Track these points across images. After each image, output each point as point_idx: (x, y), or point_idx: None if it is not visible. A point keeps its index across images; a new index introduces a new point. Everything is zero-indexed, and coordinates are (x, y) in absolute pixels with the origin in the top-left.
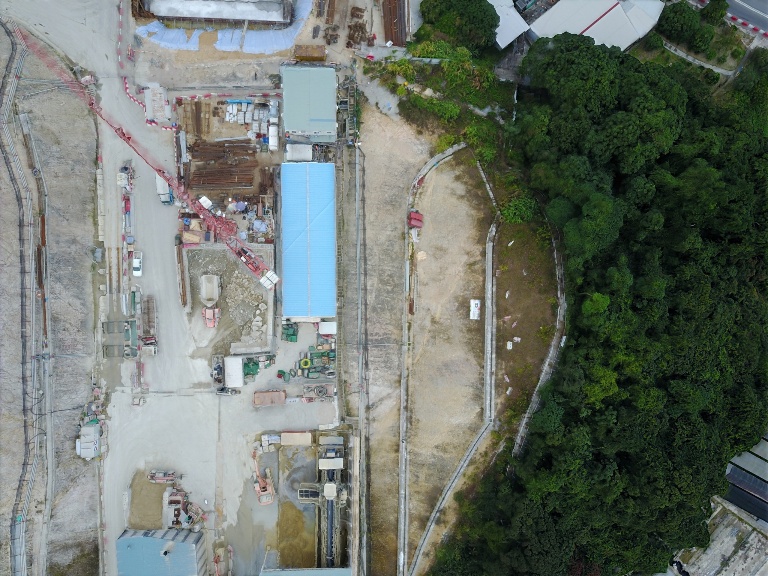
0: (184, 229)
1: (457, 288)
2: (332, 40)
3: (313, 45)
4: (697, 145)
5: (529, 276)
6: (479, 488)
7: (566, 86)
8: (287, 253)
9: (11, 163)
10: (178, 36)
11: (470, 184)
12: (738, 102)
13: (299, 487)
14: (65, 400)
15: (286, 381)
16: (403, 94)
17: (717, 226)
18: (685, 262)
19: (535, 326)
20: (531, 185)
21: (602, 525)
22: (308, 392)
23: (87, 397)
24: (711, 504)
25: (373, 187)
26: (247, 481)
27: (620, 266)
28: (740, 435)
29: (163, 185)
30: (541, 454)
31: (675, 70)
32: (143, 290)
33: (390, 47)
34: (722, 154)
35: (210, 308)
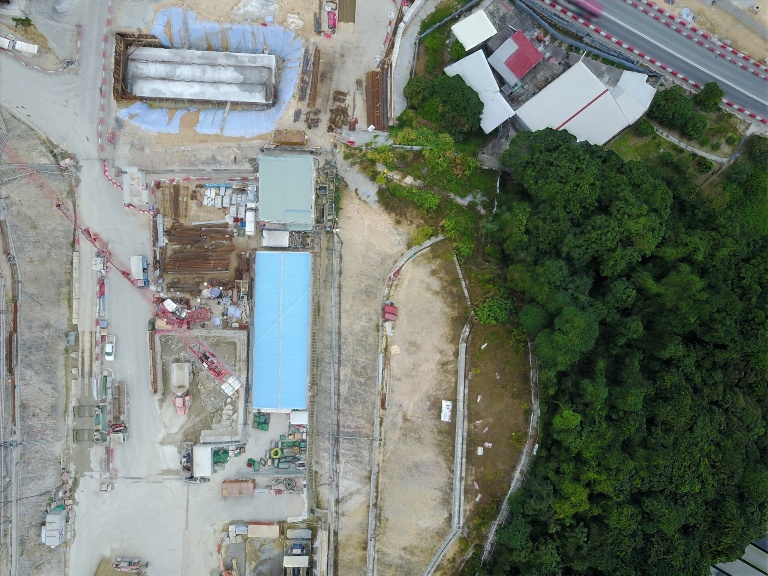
0: (157, 315)
1: (429, 387)
2: (313, 124)
3: (293, 130)
4: (680, 249)
5: (502, 380)
6: None
7: (543, 188)
8: (259, 343)
9: None
10: (159, 117)
11: (445, 280)
12: (730, 195)
13: None
14: (32, 486)
15: (256, 470)
16: (382, 182)
17: (699, 335)
18: (667, 368)
19: (507, 432)
20: (507, 285)
21: None
22: (277, 484)
23: (55, 482)
24: None
25: (349, 275)
26: (213, 571)
27: (596, 374)
28: (723, 548)
29: (137, 271)
30: (509, 568)
31: (665, 160)
32: (115, 374)
33: (372, 132)
34: (706, 260)
35: (180, 396)
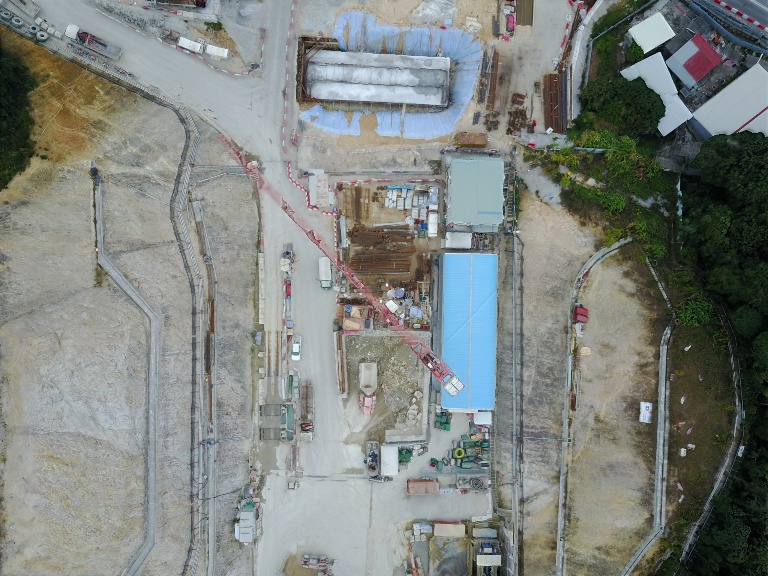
0: (345, 316)
1: (625, 388)
2: (493, 127)
3: (476, 133)
4: None
5: (705, 382)
6: None
7: (754, 192)
8: (448, 344)
9: (185, 250)
10: (338, 120)
11: (641, 282)
12: None
13: None
14: (226, 484)
15: (439, 470)
16: (567, 185)
17: None
18: None
19: (710, 433)
20: (708, 288)
21: None
22: (464, 484)
23: (244, 479)
24: None
25: (532, 277)
26: (397, 569)
27: None
28: None
29: (326, 272)
30: (718, 569)
31: None
32: (300, 374)
33: (550, 134)
34: None
35: (369, 396)
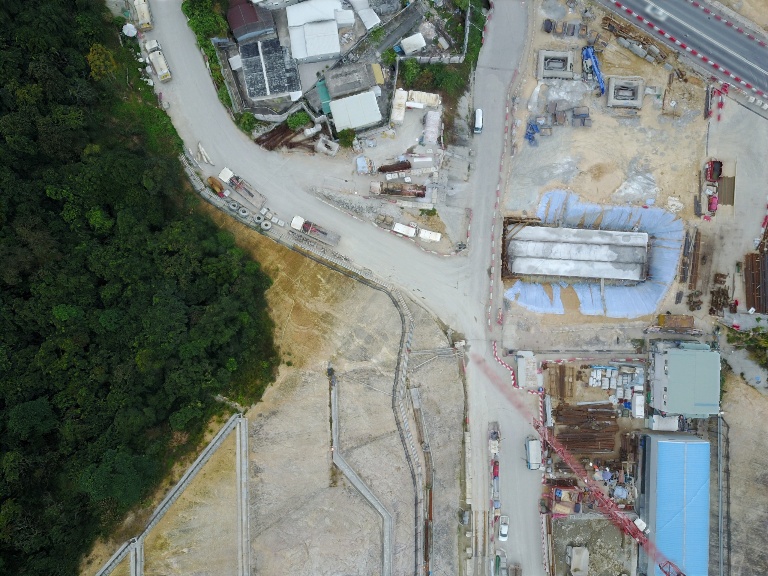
0: (556, 500)
1: None
2: (696, 307)
3: (682, 316)
4: None
5: None
6: None
7: None
8: (661, 532)
9: (405, 439)
10: (539, 296)
11: None
12: None
13: None
14: None
15: None
16: None
17: None
18: None
19: None
20: None
21: None
22: None
23: None
24: None
25: (740, 461)
26: None
27: None
28: None
29: (536, 456)
30: None
31: None
32: (507, 554)
33: (752, 314)
34: None
35: None
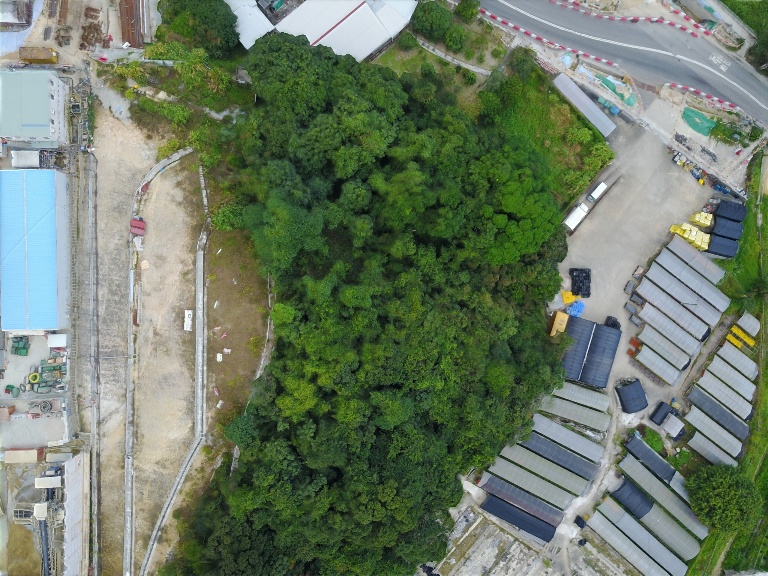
0: None
1: (174, 298)
2: (63, 42)
3: (39, 47)
4: (410, 148)
5: (239, 285)
6: (191, 506)
7: (265, 88)
8: (5, 264)
9: None
10: None
11: (188, 190)
12: (486, 103)
13: (15, 507)
14: None
15: (14, 396)
16: (131, 97)
17: (429, 231)
18: (408, 268)
19: (246, 337)
20: (243, 191)
21: (328, 541)
22: (32, 408)
23: None
24: (470, 515)
25: (104, 194)
26: None
27: (328, 274)
28: (474, 445)
29: None
30: (244, 470)
31: (423, 70)
32: None
33: (127, 49)
34: (433, 157)
35: None
